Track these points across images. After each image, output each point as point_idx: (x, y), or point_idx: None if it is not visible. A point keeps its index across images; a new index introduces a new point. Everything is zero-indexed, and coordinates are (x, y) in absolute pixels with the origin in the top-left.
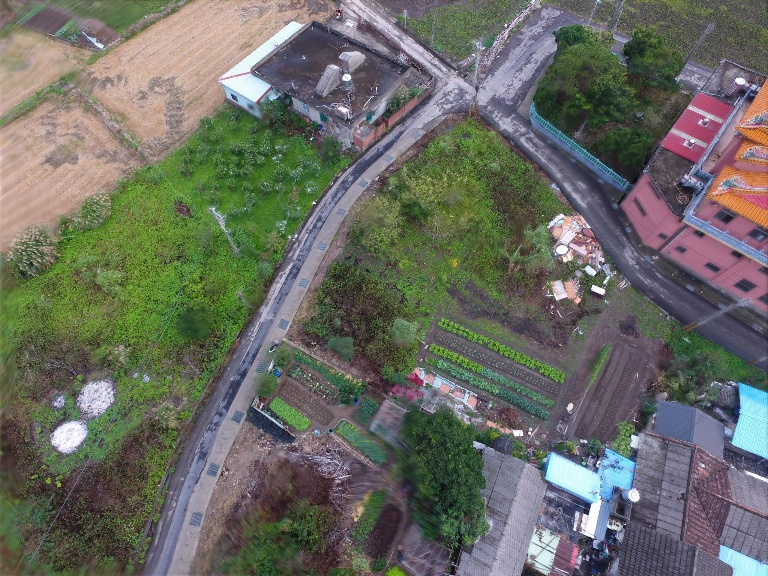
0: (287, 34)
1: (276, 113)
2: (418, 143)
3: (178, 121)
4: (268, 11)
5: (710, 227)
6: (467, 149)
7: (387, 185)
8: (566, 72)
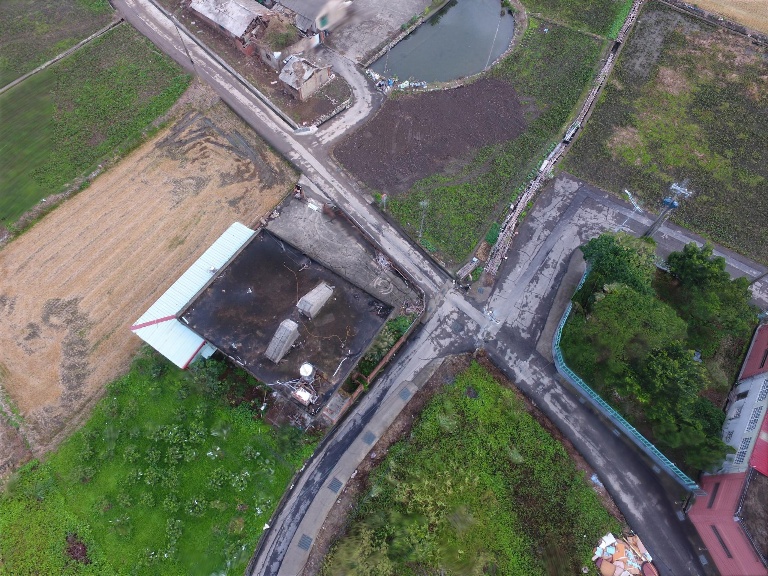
0: (228, 245)
1: (211, 385)
2: (408, 408)
3: (79, 376)
4: (207, 184)
5: None
6: (474, 417)
7: (368, 488)
8: (611, 345)
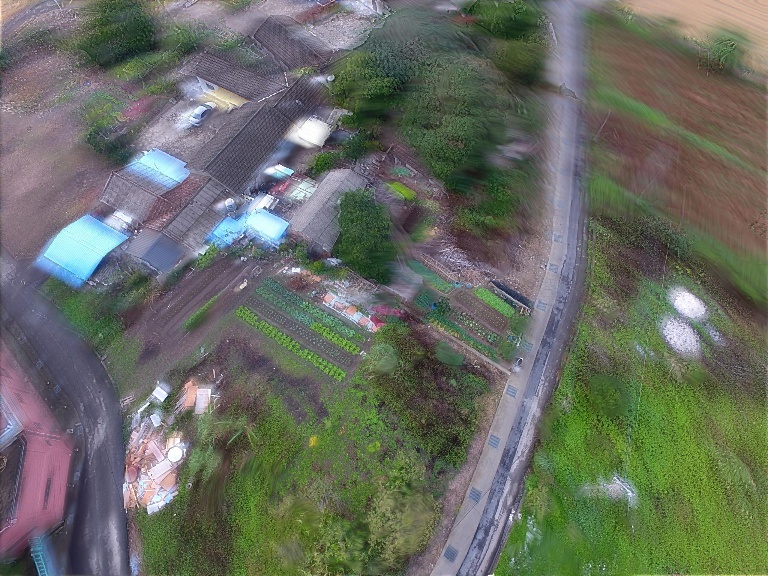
0: None
1: None
2: None
3: None
4: None
5: (2, 408)
6: None
7: None
8: None
